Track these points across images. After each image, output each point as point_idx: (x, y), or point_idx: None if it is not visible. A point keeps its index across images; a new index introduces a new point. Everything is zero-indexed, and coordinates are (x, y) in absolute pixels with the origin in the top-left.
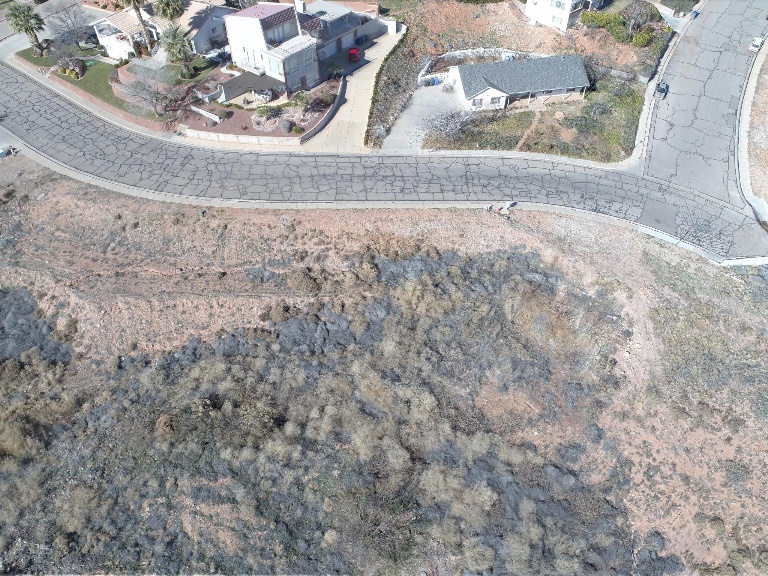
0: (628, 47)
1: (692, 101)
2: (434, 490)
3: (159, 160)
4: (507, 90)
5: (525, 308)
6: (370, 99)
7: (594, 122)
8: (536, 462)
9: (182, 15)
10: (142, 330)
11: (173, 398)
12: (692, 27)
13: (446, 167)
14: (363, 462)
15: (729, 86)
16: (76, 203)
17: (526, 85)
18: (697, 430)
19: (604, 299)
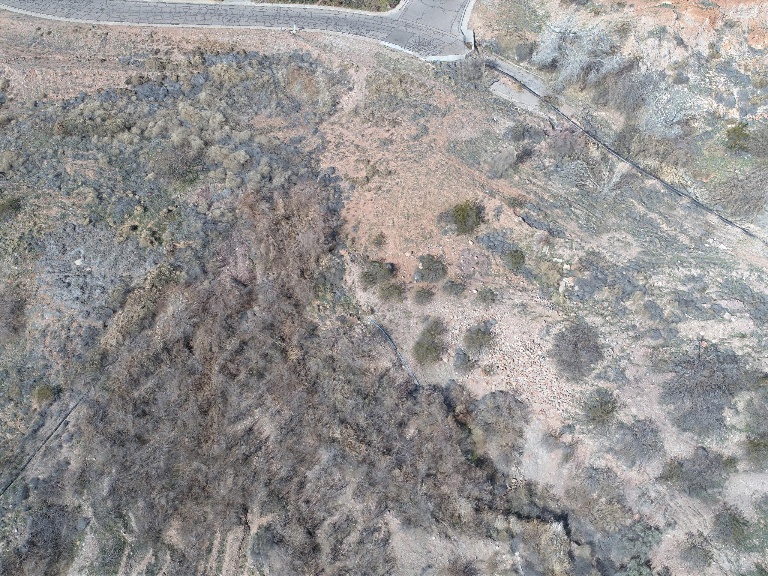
0: None
1: None
2: (214, 155)
3: (69, 3)
4: None
5: (291, 77)
6: None
7: None
8: (276, 143)
9: None
10: (50, 87)
11: (67, 119)
12: None
13: (264, 11)
14: (176, 146)
15: None
16: (12, 22)
17: None
18: (372, 127)
19: (343, 74)
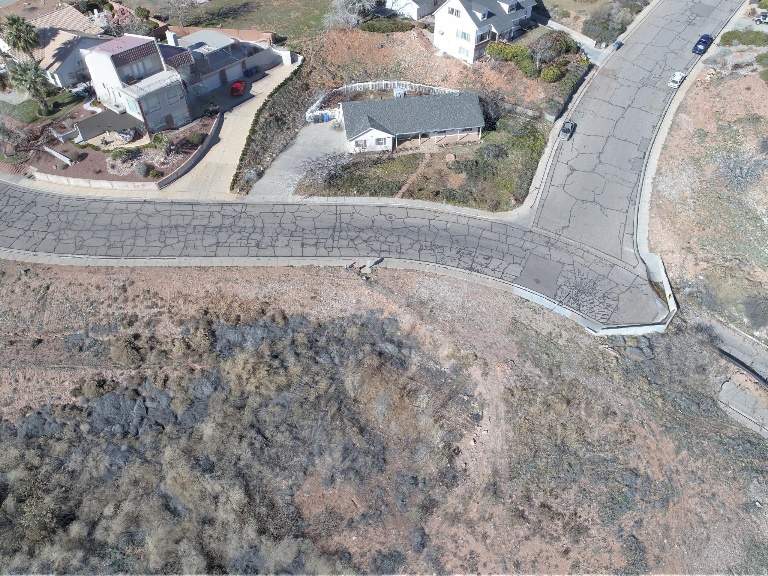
0: (536, 82)
1: (599, 143)
2: None
3: None
4: (393, 130)
5: (368, 385)
6: (245, 139)
7: (485, 167)
8: (346, 575)
9: (47, 46)
10: None
11: None
12: (613, 59)
13: (315, 217)
14: (153, 570)
15: (641, 126)
16: None
17: (415, 125)
18: (533, 539)
19: (459, 375)
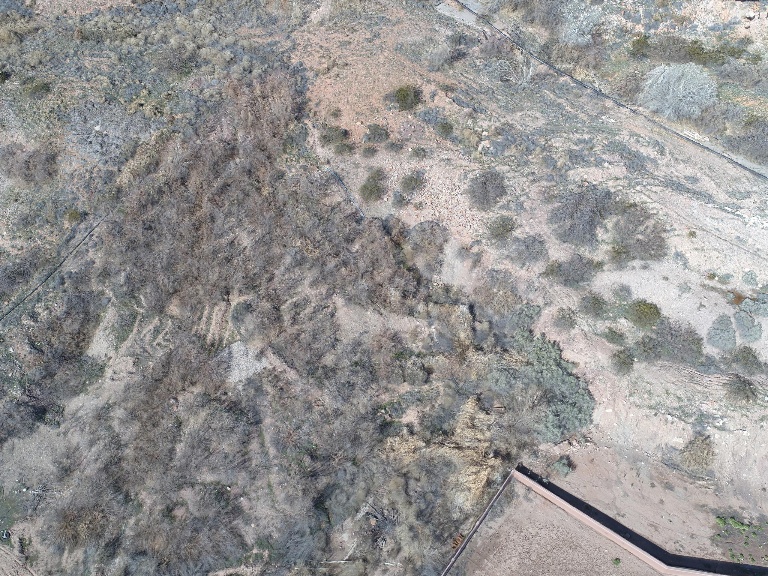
0: None
1: None
2: (205, 55)
3: None
4: None
5: None
6: None
7: None
8: (255, 46)
9: None
10: (69, 4)
11: None
12: None
13: None
14: (174, 49)
15: None
16: None
17: None
18: (335, 34)
19: None
